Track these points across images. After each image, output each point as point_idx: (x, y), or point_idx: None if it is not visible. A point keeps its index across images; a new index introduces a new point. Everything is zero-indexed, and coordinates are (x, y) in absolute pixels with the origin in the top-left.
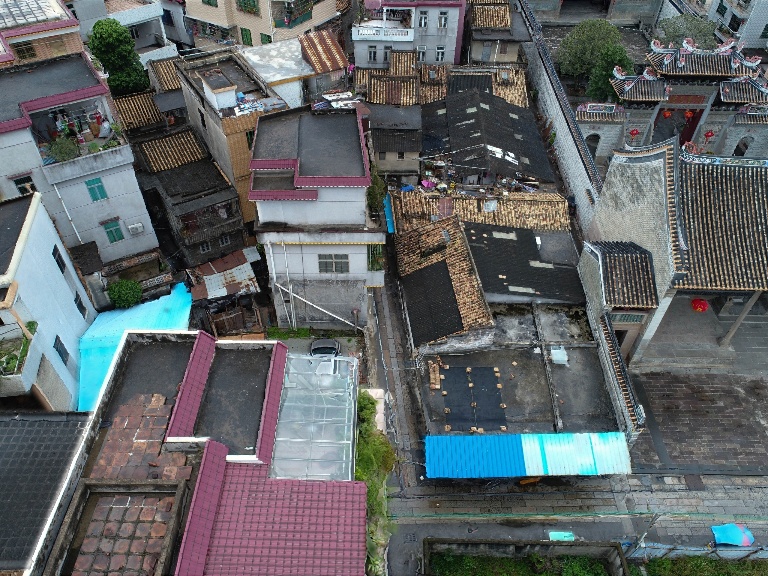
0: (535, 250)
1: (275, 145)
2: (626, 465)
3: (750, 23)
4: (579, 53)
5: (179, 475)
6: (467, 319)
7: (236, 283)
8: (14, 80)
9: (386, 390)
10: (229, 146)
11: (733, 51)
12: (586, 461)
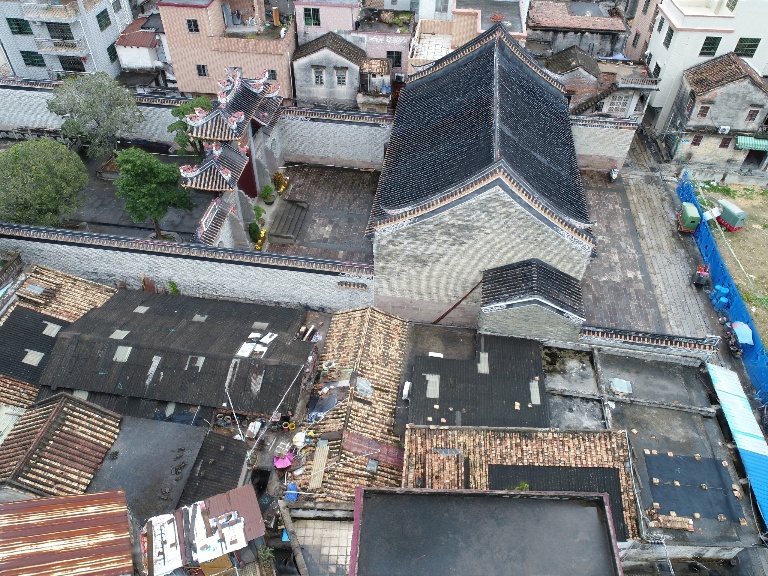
0: (456, 362)
1: None
2: (732, 374)
3: (97, 56)
4: (55, 194)
5: None
6: (604, 460)
7: None
8: None
9: None
10: None
11: (241, 79)
12: (740, 402)
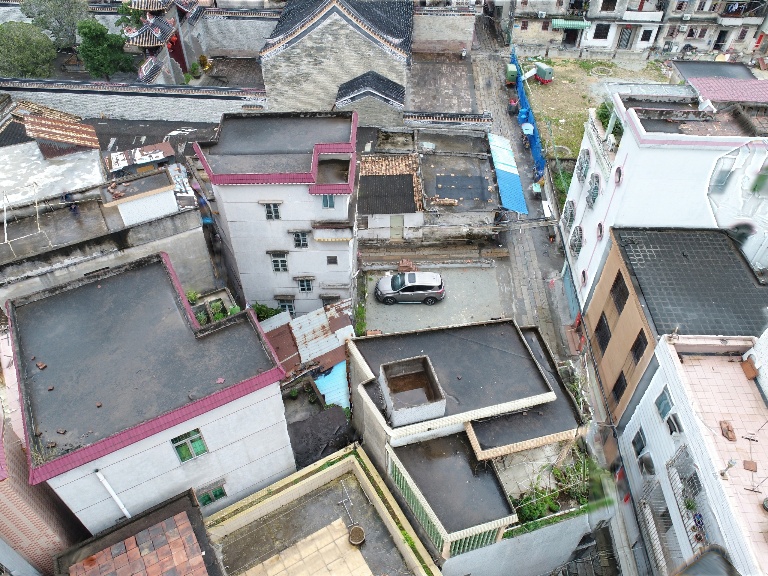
0: None
1: (272, 167)
2: (506, 140)
3: None
4: (32, 58)
5: (731, 109)
6: (403, 171)
7: (331, 322)
8: (71, 380)
9: (425, 260)
10: (204, 238)
11: None
12: (506, 152)
